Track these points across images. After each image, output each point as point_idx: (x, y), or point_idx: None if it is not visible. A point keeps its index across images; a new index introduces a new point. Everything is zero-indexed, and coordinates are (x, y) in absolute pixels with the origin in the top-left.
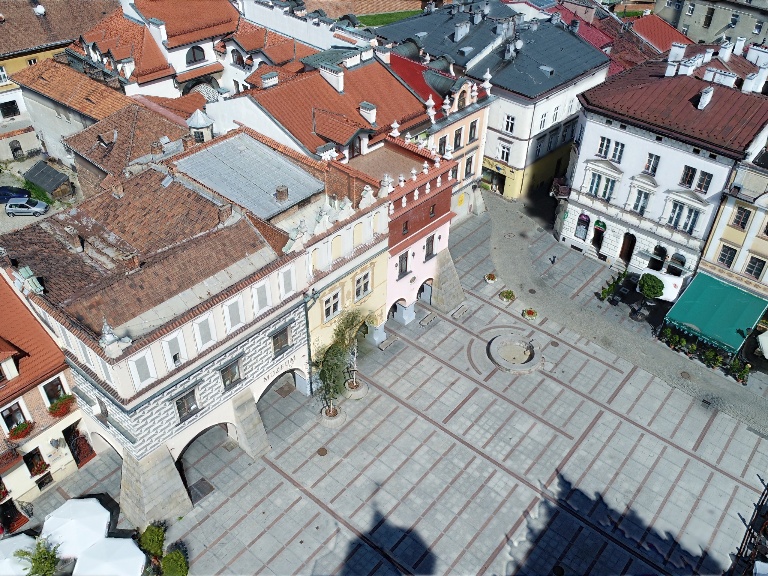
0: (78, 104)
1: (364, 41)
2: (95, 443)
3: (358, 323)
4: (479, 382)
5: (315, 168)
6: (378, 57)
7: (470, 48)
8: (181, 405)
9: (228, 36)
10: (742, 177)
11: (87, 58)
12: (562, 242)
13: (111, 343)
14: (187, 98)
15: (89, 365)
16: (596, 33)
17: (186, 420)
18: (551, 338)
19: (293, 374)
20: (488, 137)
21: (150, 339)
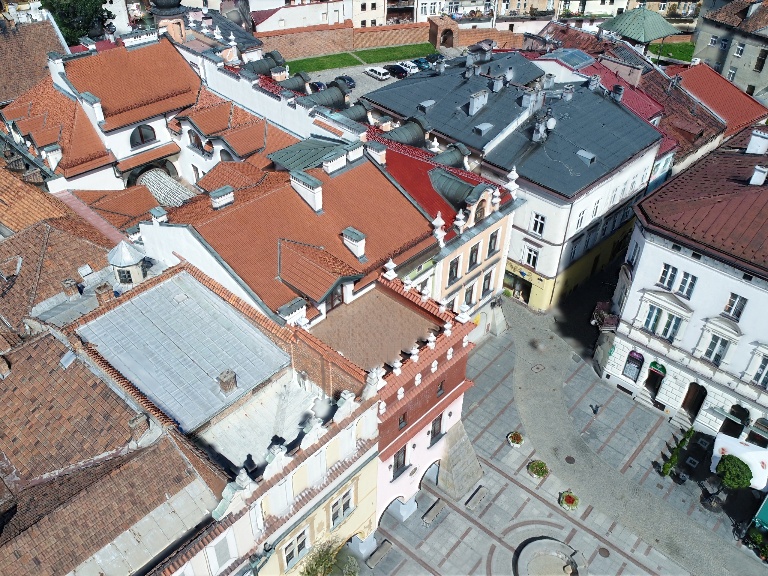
0: None
1: (352, 134)
2: None
3: (336, 548)
4: None
5: (277, 336)
6: (370, 155)
7: (489, 125)
8: None
9: (185, 110)
10: None
11: (9, 137)
12: (605, 379)
13: None
14: (128, 195)
15: None
16: (643, 99)
17: None
18: (599, 542)
19: None
20: None
21: None
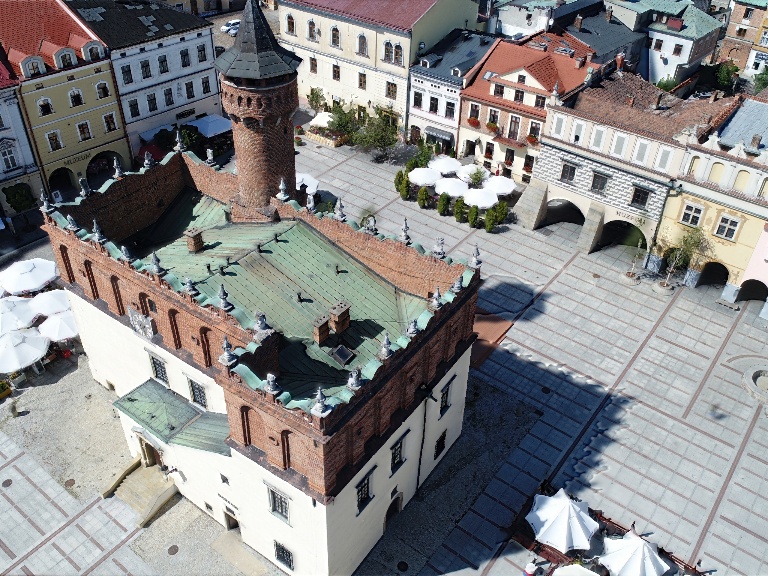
0: None
1: None
2: None
3: (710, 257)
4: (717, 360)
5: None
6: None
7: None
8: (567, 171)
9: None
10: None
11: None
12: None
13: None
14: None
15: None
16: None
17: (564, 182)
18: None
19: None
20: None
21: (569, 111)
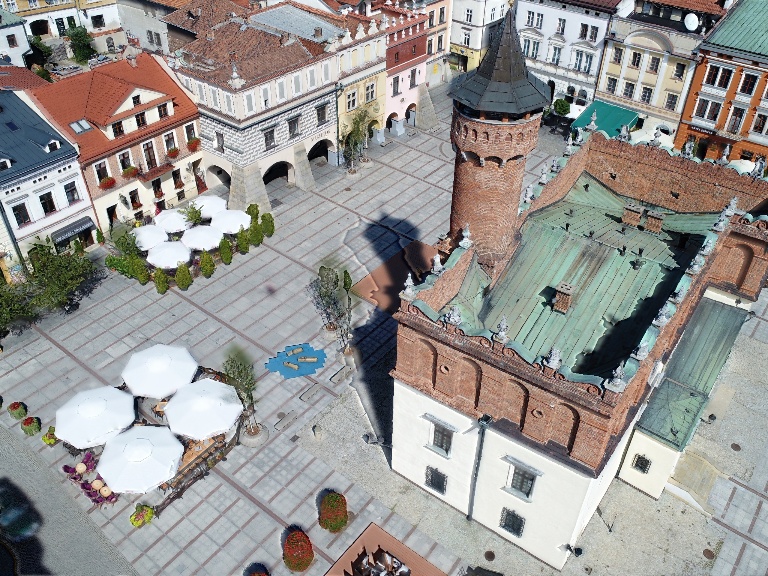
0: (164, 1)
1: None
2: (208, 180)
3: (367, 121)
4: (447, 161)
5: (338, 20)
6: None
7: None
8: (267, 139)
9: None
10: (615, 26)
11: None
12: None
13: (236, 78)
14: None
15: (216, 107)
16: None
17: (269, 150)
18: None
19: (327, 152)
20: (454, 28)
21: (255, 83)
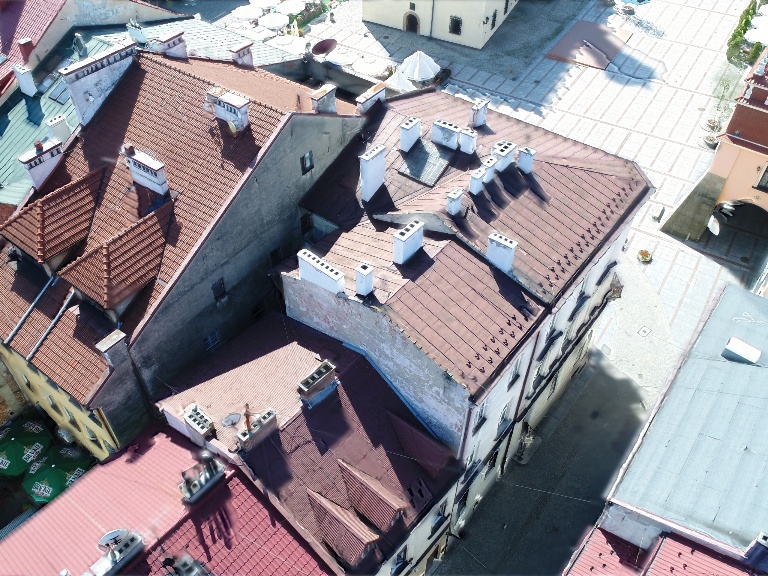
0: None
1: None
2: None
3: None
4: None
5: None
6: None
7: None
8: None
9: None
10: None
11: None
12: None
13: None
14: None
15: None
16: None
17: None
18: None
19: None
20: None
21: None
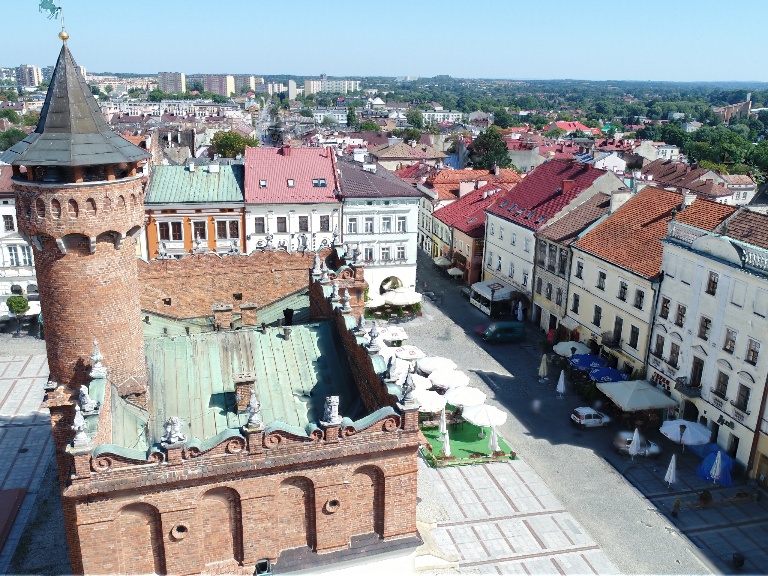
0: None
1: None
2: None
3: None
4: None
5: None
6: None
7: None
8: None
9: None
10: None
11: None
12: None
13: None
14: None
15: None
16: None
17: None
18: None
19: None
20: None
21: None
